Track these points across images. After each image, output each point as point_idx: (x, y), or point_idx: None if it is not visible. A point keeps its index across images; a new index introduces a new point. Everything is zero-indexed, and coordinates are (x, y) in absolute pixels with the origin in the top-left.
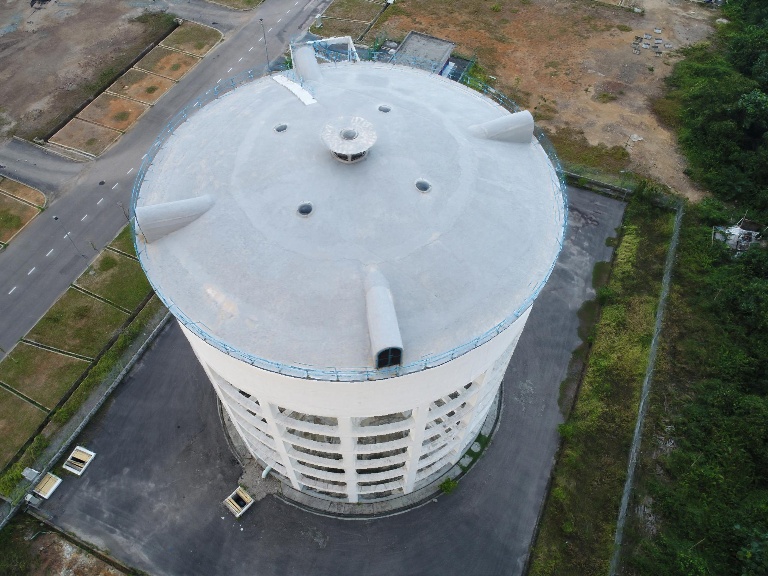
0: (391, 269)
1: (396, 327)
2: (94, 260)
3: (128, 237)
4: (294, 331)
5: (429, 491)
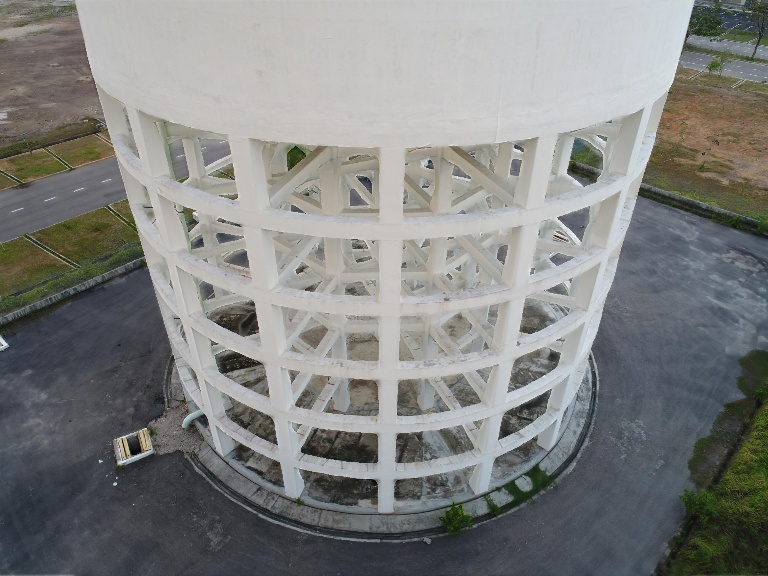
0: None
1: None
2: None
3: None
4: None
5: (422, 522)
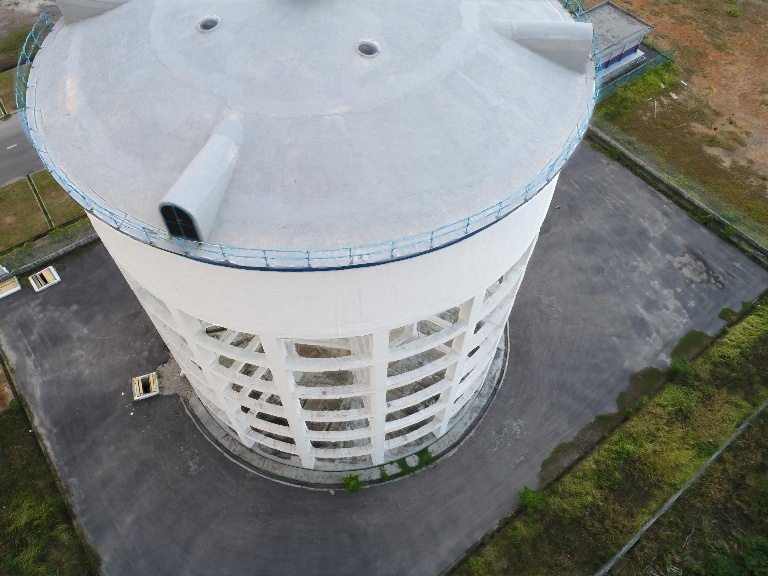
0: (257, 125)
1: (205, 188)
2: None
3: None
4: (110, 153)
5: (332, 478)
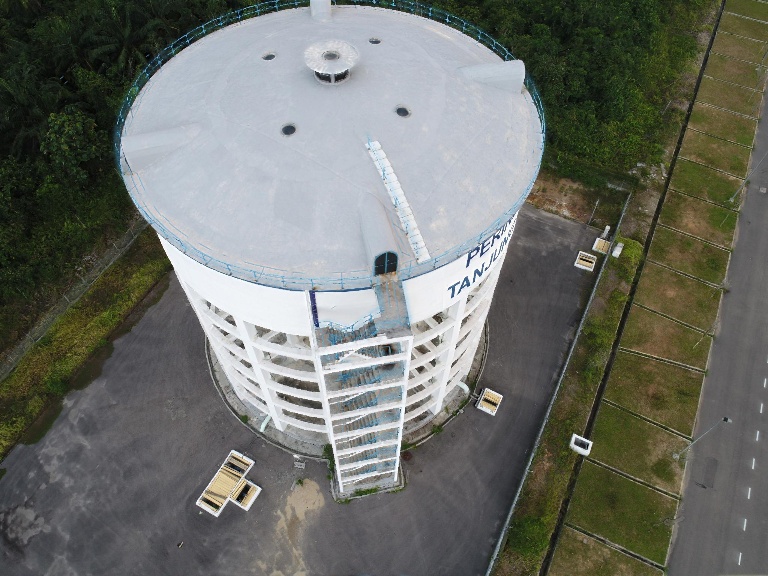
0: None
1: None
2: (684, 477)
3: (658, 514)
4: (384, 15)
5: None
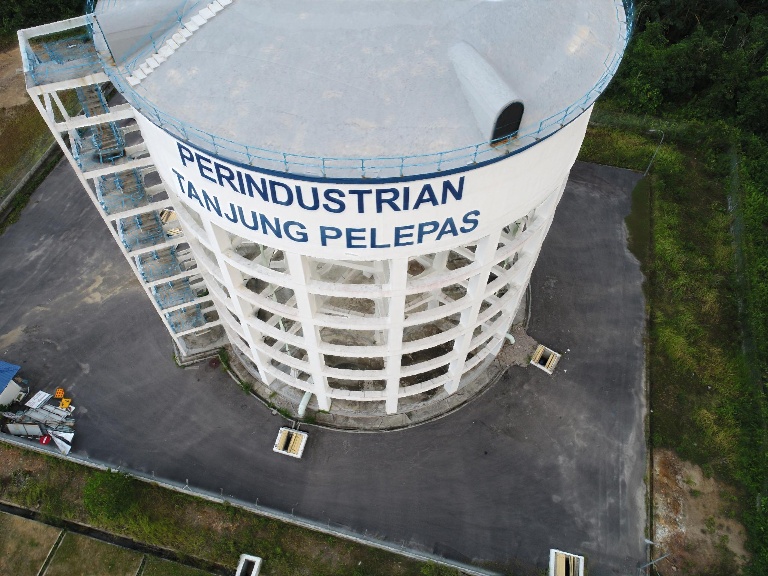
0: None
1: None
2: None
3: None
4: None
5: None
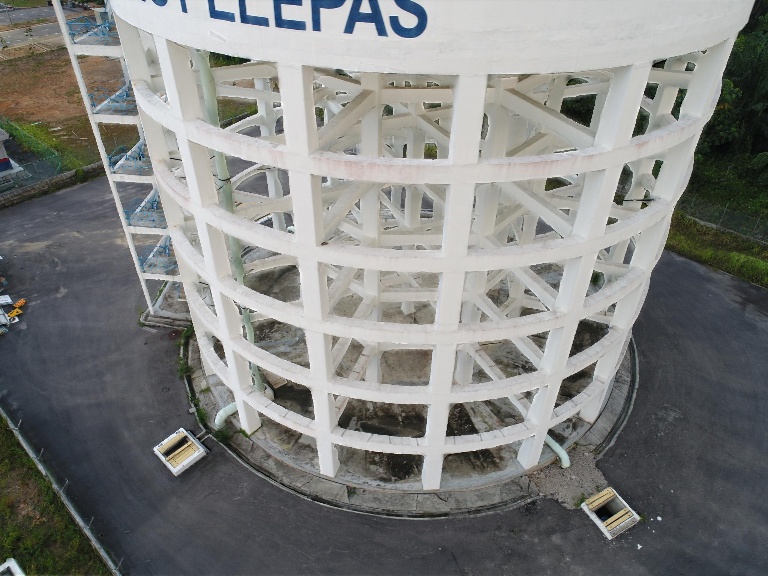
0: None
1: None
2: None
3: None
4: None
5: None
